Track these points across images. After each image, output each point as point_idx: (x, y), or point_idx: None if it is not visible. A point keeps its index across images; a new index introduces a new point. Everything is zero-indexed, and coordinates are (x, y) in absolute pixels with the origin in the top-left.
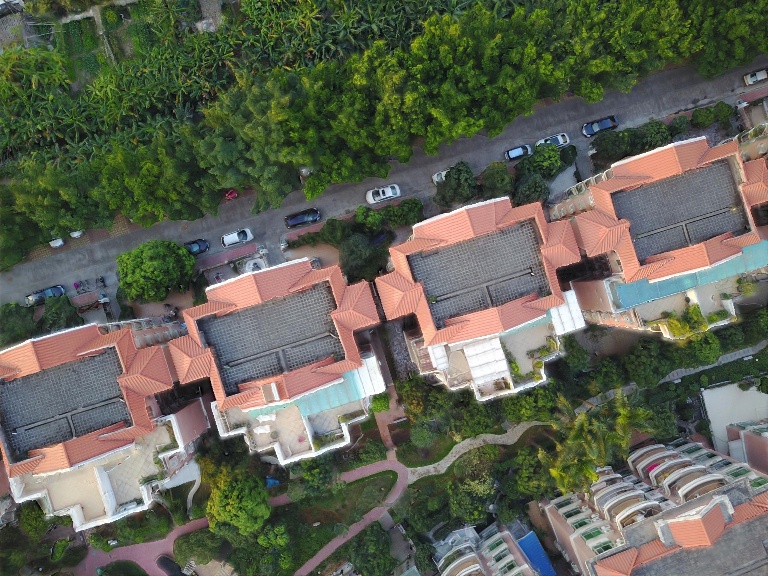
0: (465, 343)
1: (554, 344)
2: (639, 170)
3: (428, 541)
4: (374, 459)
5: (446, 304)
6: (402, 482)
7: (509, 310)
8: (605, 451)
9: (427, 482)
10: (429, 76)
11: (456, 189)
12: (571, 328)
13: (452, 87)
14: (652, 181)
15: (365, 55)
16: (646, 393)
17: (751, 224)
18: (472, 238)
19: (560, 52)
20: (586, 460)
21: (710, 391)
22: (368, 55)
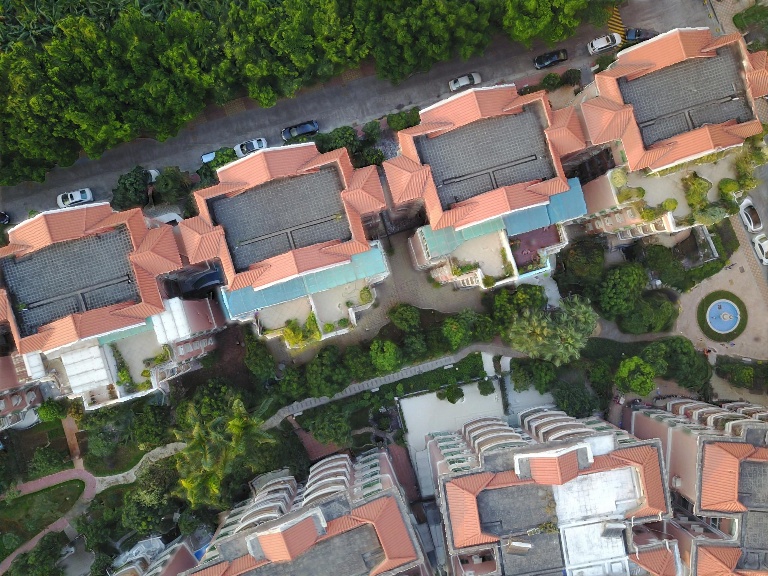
0: (63, 351)
1: (168, 353)
2: (238, 176)
3: (115, 552)
4: (42, 468)
5: (39, 311)
6: (89, 491)
7: (90, 318)
8: (224, 462)
9: (114, 492)
10: (75, 79)
11: (125, 194)
12: (174, 336)
13: (94, 90)
14: (249, 187)
15: (1, 57)
16: (341, 402)
17: (352, 232)
18: (68, 244)
19: (216, 56)
20: (211, 471)
21: (407, 400)
22: (4, 57)
